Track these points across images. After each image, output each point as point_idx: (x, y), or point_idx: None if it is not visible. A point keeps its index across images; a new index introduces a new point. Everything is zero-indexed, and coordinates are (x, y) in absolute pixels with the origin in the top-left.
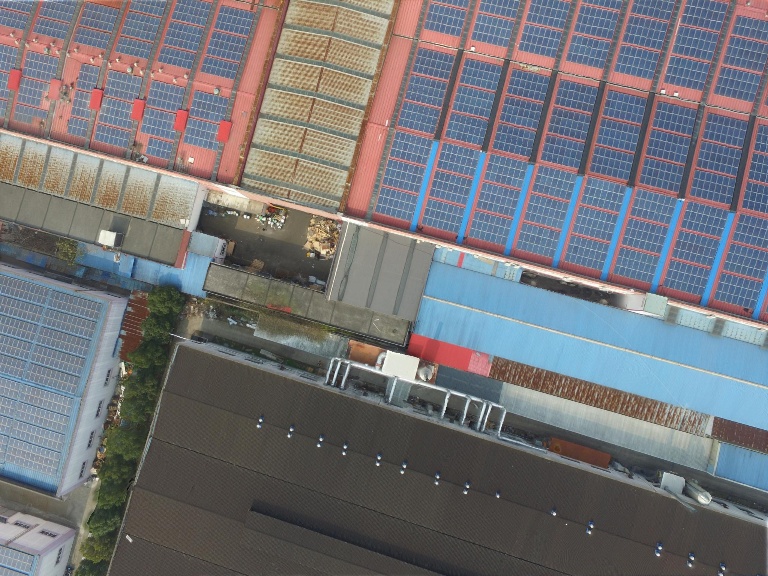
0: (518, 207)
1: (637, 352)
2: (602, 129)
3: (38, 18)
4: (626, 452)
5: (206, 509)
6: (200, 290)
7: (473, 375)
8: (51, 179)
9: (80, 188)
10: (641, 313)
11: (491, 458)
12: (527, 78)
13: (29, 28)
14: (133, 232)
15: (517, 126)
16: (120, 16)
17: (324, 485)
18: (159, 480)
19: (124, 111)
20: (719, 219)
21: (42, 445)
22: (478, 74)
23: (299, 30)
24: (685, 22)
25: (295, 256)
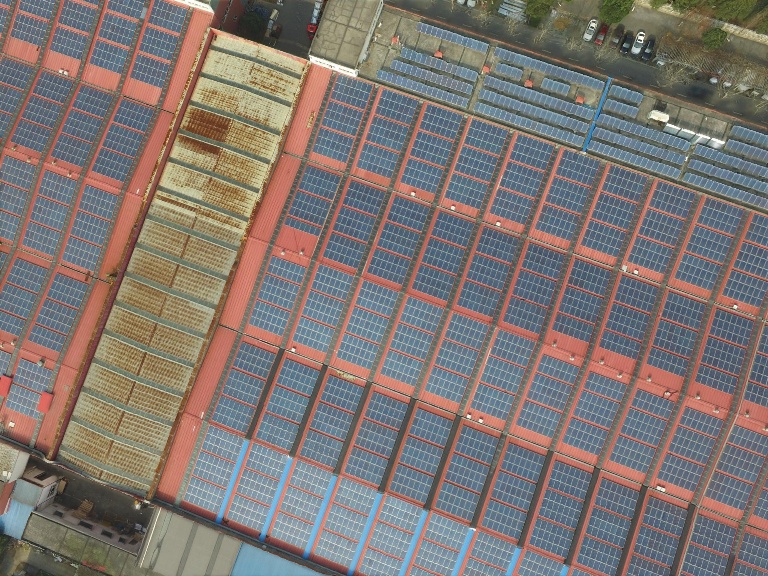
0: (320, 514)
1: None
2: (407, 447)
3: None
4: None
5: None
6: None
7: None
8: None
9: None
10: None
11: None
12: (342, 386)
13: None
14: None
15: (326, 434)
16: None
17: None
18: None
19: None
20: (507, 552)
21: None
22: (295, 376)
23: (128, 310)
24: (495, 353)
25: (125, 500)
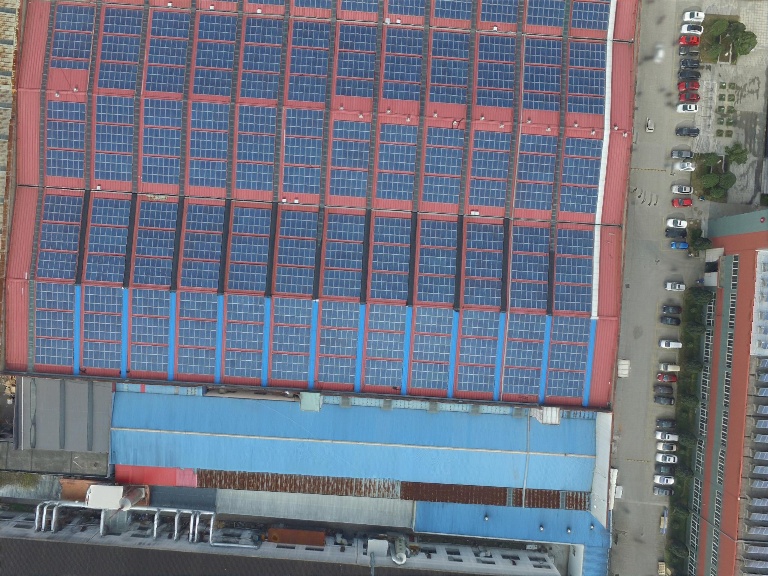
0: (170, 334)
1: (318, 440)
2: (234, 246)
3: None
4: None
5: None
6: None
7: (181, 489)
8: None
9: None
10: None
11: (204, 567)
12: (156, 208)
13: None
14: None
15: (154, 257)
16: None
17: None
18: None
19: None
20: (353, 312)
21: None
22: (108, 212)
23: None
24: (289, 133)
25: None
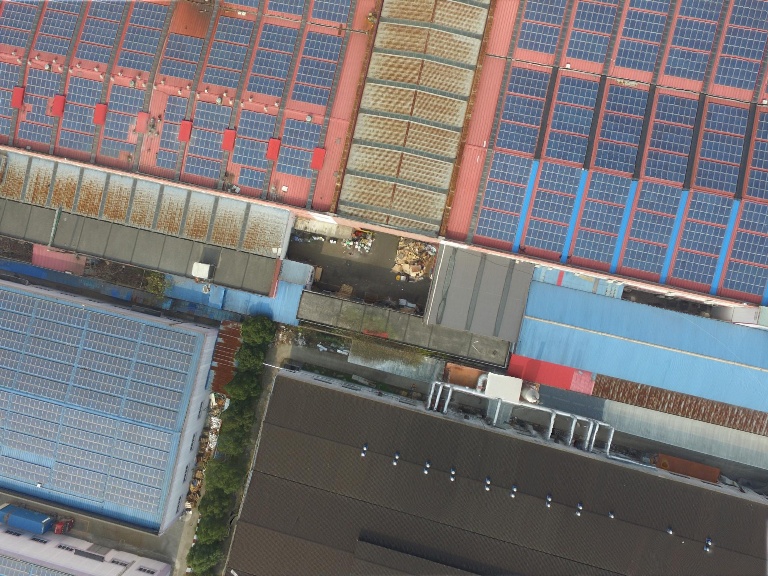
0: (623, 224)
1: (746, 365)
2: (705, 142)
3: (122, 51)
4: (731, 464)
5: (313, 541)
6: (292, 318)
7: (576, 394)
8: (138, 212)
9: (168, 220)
10: (750, 326)
11: (602, 478)
12: (625, 93)
13: (113, 62)
14: (224, 263)
15: (618, 142)
16: (206, 46)
17: (433, 512)
18: (263, 513)
19: (214, 142)
20: None
21: (142, 482)
22: (575, 91)
23: (390, 54)
24: None
25: (383, 279)
